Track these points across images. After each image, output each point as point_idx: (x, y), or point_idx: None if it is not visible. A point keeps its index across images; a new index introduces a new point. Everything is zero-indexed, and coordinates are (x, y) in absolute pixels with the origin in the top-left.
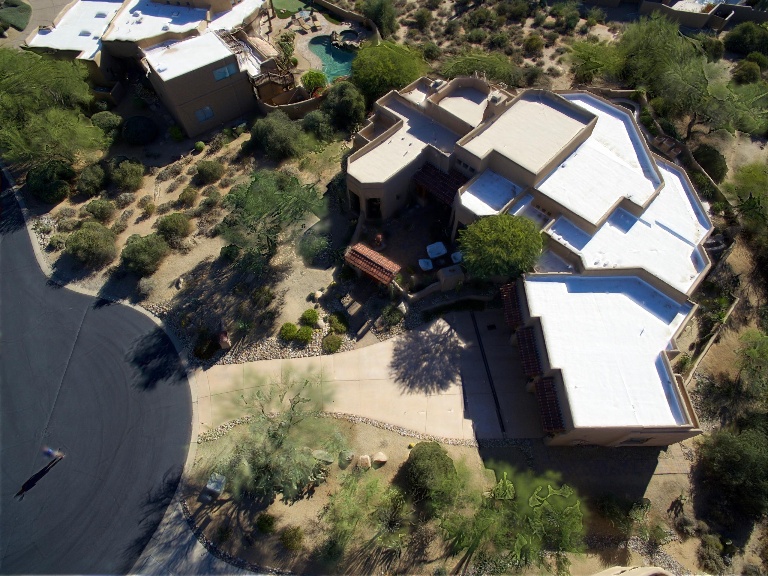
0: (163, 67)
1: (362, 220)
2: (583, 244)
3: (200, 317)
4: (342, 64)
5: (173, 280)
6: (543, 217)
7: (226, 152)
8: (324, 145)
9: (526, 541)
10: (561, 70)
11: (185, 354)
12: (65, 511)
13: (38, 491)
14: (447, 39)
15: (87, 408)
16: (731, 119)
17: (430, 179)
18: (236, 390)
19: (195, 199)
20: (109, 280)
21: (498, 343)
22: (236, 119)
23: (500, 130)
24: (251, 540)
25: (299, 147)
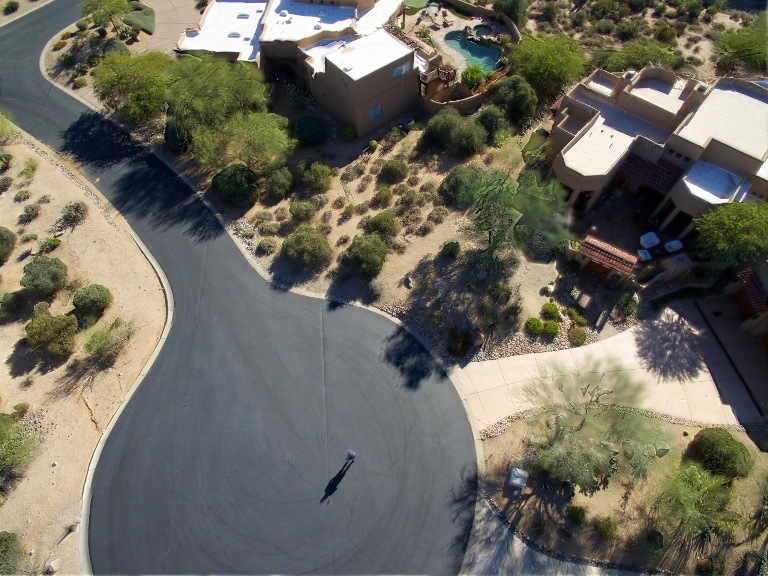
0: (349, 66)
1: None
2: None
3: None
4: (482, 59)
5: (399, 280)
6: None
7: (401, 150)
8: None
9: None
10: (702, 59)
11: (437, 353)
12: (376, 513)
13: (342, 495)
14: (577, 31)
15: (360, 410)
16: None
17: (639, 170)
18: (500, 386)
19: (391, 198)
20: (333, 282)
21: (729, 329)
22: (398, 117)
23: (706, 119)
24: (568, 532)
25: (481, 143)
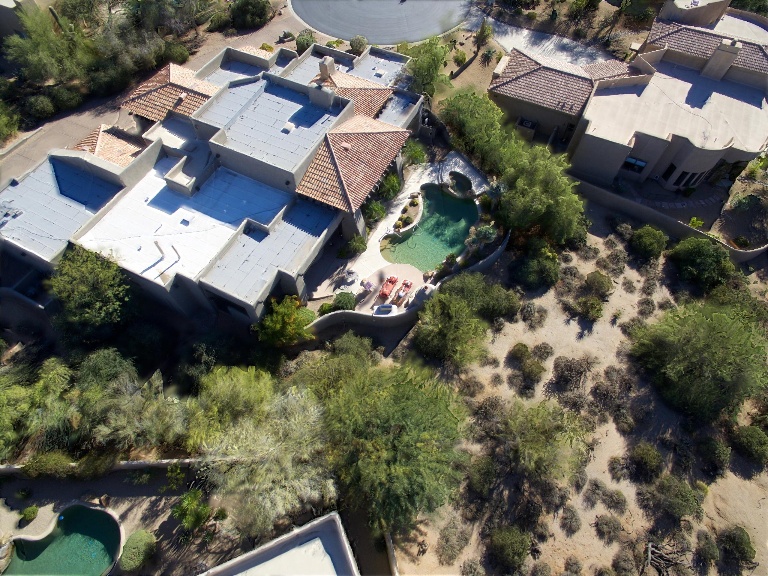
0: None
1: None
2: None
3: None
4: None
5: None
6: None
7: None
8: None
9: None
10: None
11: None
12: (425, 7)
13: None
14: None
15: None
16: None
17: None
18: None
19: None
20: None
21: None
22: None
23: None
24: (514, 15)
25: None
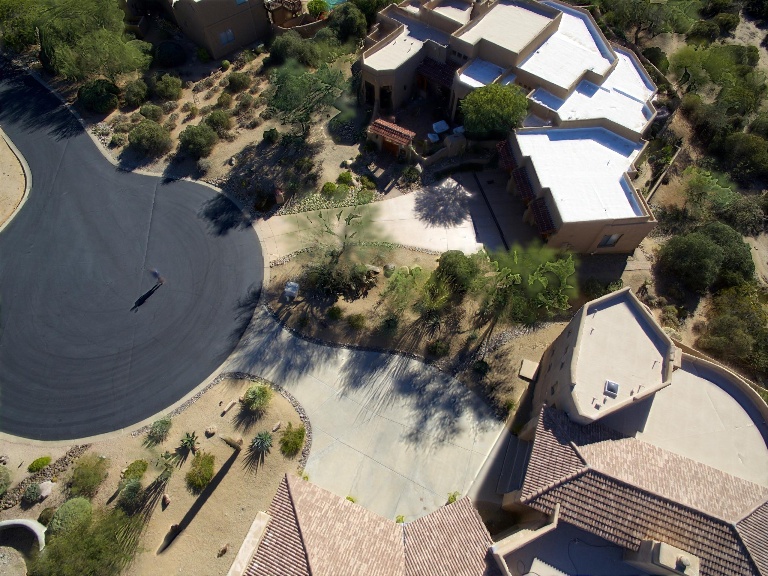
0: None
1: (377, 108)
2: (559, 106)
3: (256, 181)
4: None
5: (226, 160)
6: (525, 92)
7: (250, 68)
8: (335, 57)
9: None
10: None
11: (247, 210)
12: (174, 316)
13: (148, 306)
14: None
15: (174, 250)
16: (668, 19)
17: (431, 69)
18: (294, 232)
19: (231, 102)
20: (170, 164)
21: (497, 192)
22: (253, 43)
23: (485, 26)
24: (325, 324)
25: (315, 58)
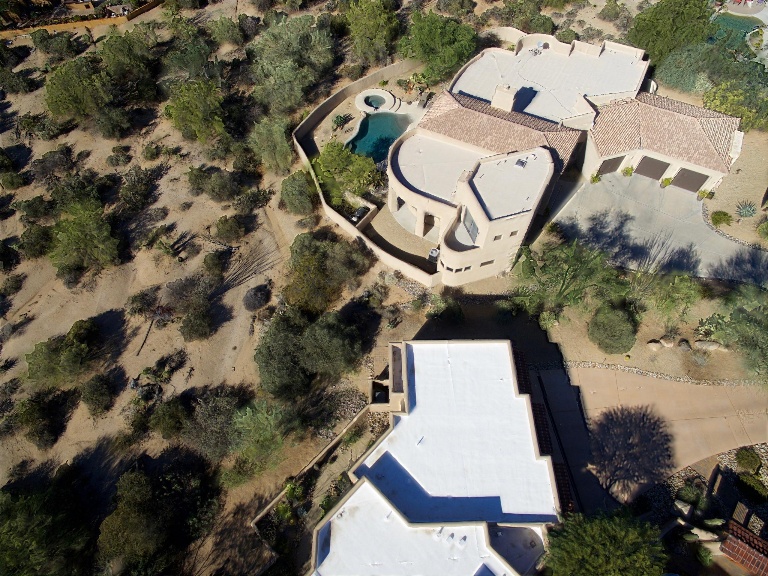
0: None
1: None
2: None
3: None
4: None
5: None
6: None
7: None
8: None
9: (568, 251)
10: None
11: None
12: None
13: None
14: None
15: None
16: None
17: None
18: None
19: None
20: None
21: None
22: None
23: None
24: (736, 290)
25: None
